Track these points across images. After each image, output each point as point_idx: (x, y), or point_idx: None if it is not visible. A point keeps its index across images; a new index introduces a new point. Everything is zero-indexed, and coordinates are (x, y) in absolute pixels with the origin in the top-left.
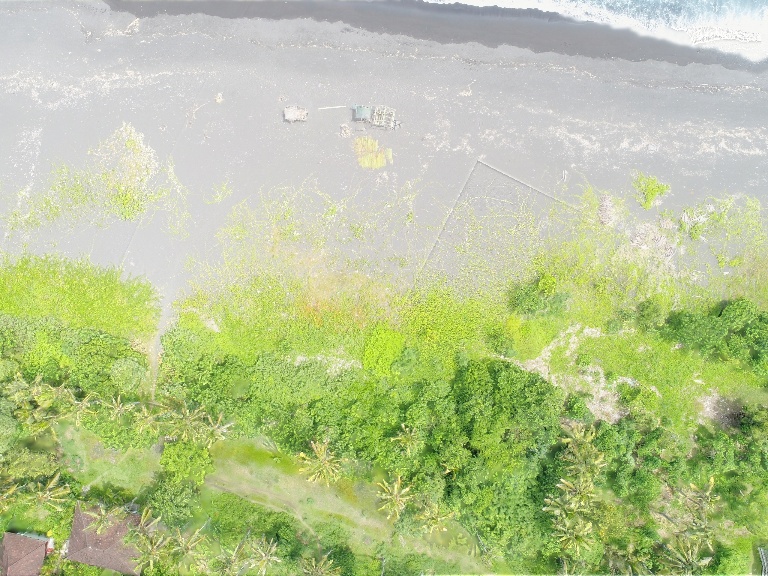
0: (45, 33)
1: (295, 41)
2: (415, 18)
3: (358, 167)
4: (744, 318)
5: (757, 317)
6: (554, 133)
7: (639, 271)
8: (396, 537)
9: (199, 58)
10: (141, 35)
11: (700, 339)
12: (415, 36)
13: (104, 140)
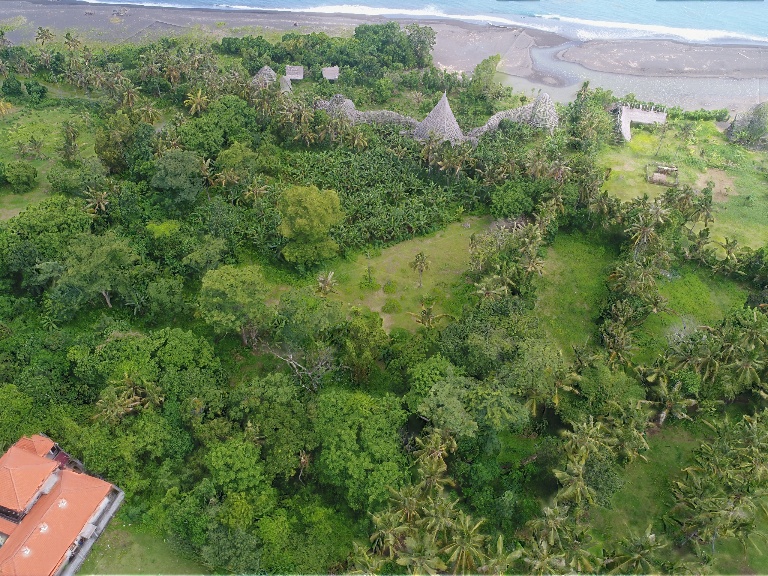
0: (3, 5)
1: (100, 7)
2: (149, 7)
3: (109, 22)
4: (246, 37)
5: (253, 39)
6: (189, 17)
7: (213, 39)
8: (73, 94)
9: (60, 8)
10: (41, 6)
11: (227, 40)
12: (146, 8)
13: (8, 18)
